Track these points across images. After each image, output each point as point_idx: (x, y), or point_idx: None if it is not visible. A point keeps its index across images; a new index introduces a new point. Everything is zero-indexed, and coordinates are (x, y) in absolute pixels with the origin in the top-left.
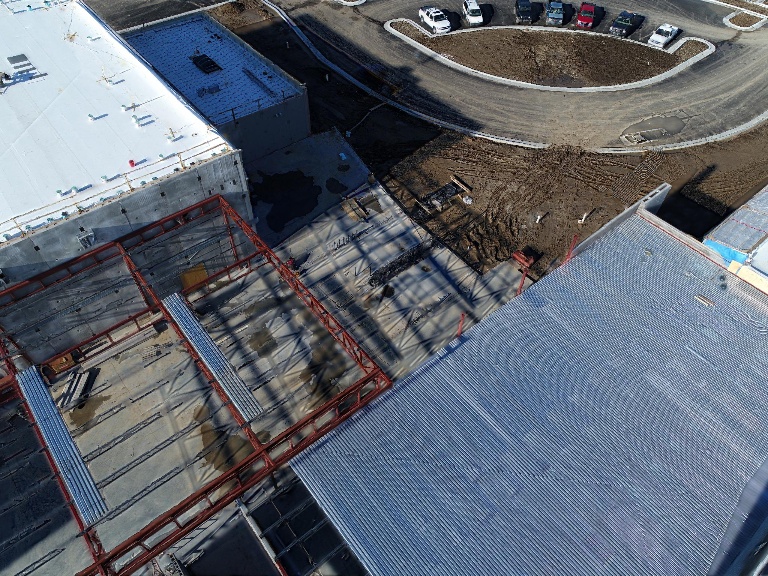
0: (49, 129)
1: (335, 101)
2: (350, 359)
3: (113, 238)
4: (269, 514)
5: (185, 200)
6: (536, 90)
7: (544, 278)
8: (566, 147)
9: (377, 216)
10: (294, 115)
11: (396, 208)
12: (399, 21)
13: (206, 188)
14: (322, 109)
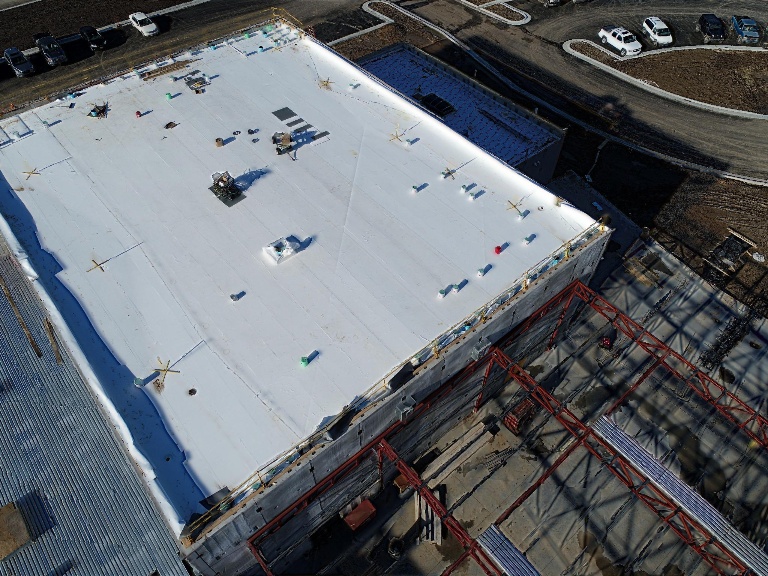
0: (374, 205)
1: None
2: (725, 465)
3: (493, 342)
4: None
5: (555, 290)
6: (763, 120)
7: None
8: None
9: (670, 279)
10: (546, 162)
11: (686, 269)
12: (578, 42)
13: (573, 274)
14: None
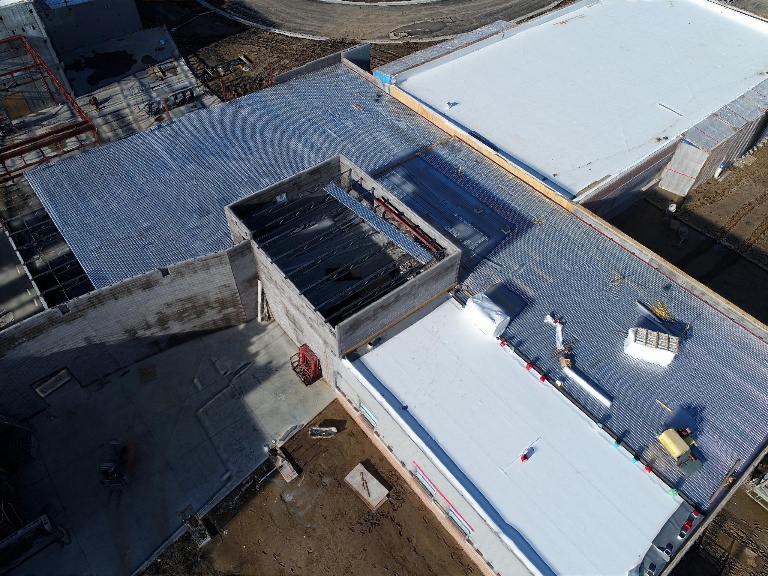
0: None
1: (173, 9)
2: None
3: None
4: (3, 197)
5: None
6: (340, 4)
7: (249, 94)
8: (342, 39)
9: (172, 77)
10: (123, 9)
11: (188, 73)
12: None
13: (9, 28)
14: (160, 14)
